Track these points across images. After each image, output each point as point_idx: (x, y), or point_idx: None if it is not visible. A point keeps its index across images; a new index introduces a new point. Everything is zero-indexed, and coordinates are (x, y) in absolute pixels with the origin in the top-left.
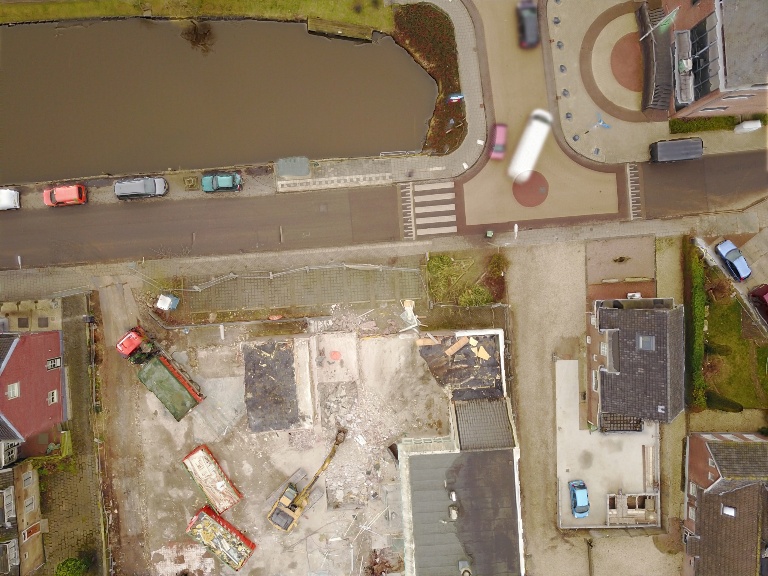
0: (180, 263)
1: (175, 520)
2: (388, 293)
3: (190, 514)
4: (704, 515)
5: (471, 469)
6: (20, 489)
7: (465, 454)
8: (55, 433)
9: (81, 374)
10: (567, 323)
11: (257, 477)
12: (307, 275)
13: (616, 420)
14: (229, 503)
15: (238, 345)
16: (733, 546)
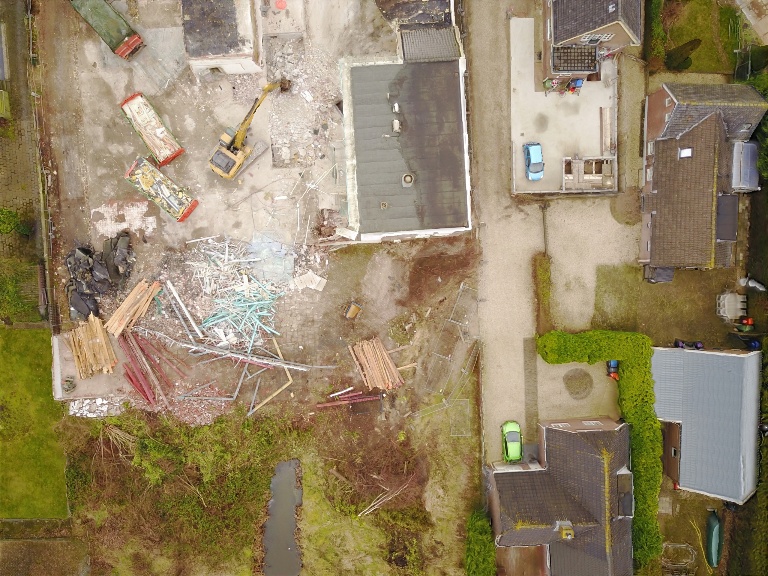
0: None
1: (115, 177)
2: None
3: None
4: (661, 167)
5: (415, 81)
6: None
7: (409, 65)
8: None
9: (18, 32)
10: None
11: (200, 132)
12: None
13: (570, 59)
14: (170, 152)
15: None
16: (690, 188)
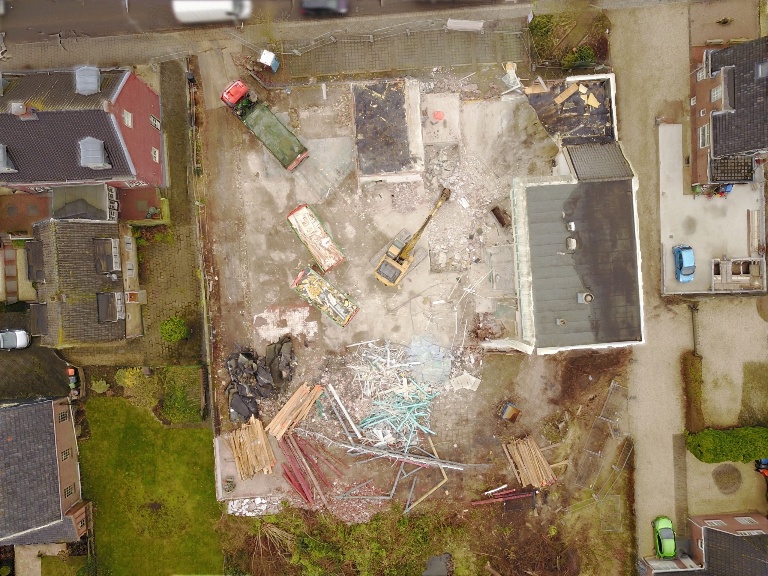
0: (279, 27)
1: (277, 283)
2: (489, 57)
3: (293, 277)
4: None
5: (589, 200)
6: (123, 247)
7: (583, 185)
8: (154, 200)
9: (180, 141)
10: (670, 86)
11: (360, 239)
12: (408, 38)
13: (727, 169)
14: (334, 260)
15: (340, 105)
16: None
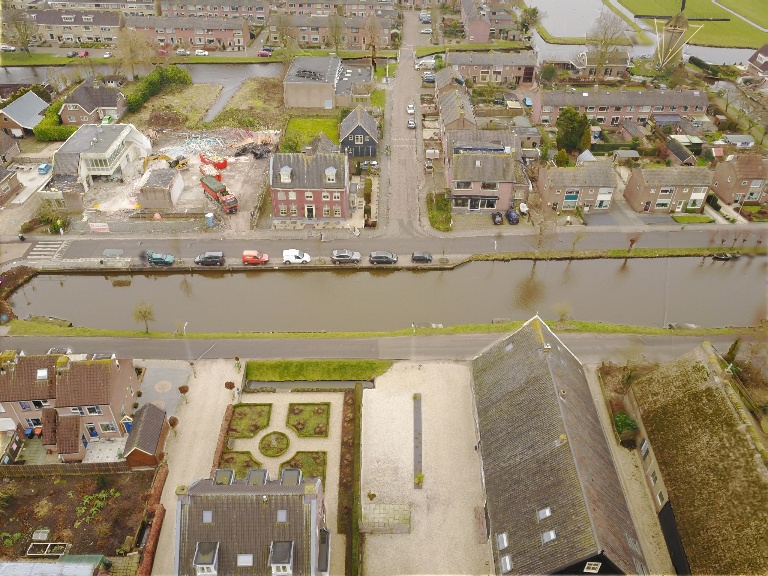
0: (201, 237)
1: None
2: None
3: None
4: None
5: None
6: None
7: None
8: None
9: (269, 209)
10: (6, 213)
11: None
12: None
13: None
14: None
15: None
16: None
